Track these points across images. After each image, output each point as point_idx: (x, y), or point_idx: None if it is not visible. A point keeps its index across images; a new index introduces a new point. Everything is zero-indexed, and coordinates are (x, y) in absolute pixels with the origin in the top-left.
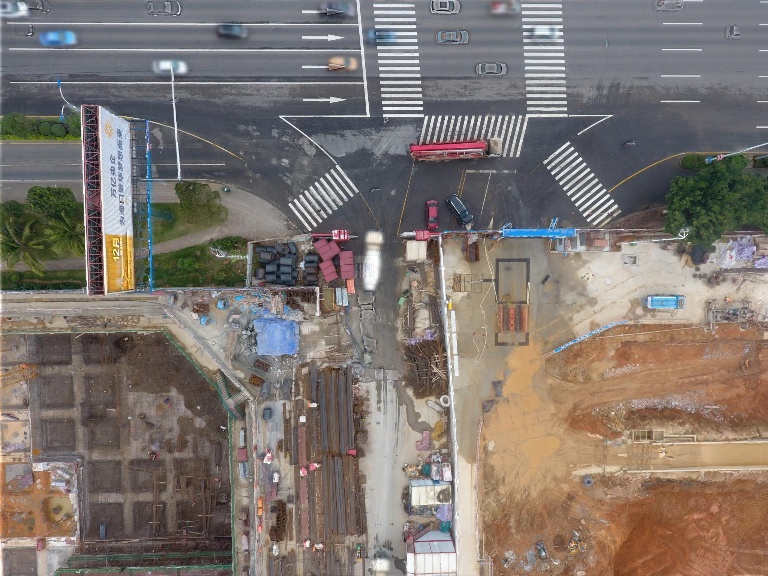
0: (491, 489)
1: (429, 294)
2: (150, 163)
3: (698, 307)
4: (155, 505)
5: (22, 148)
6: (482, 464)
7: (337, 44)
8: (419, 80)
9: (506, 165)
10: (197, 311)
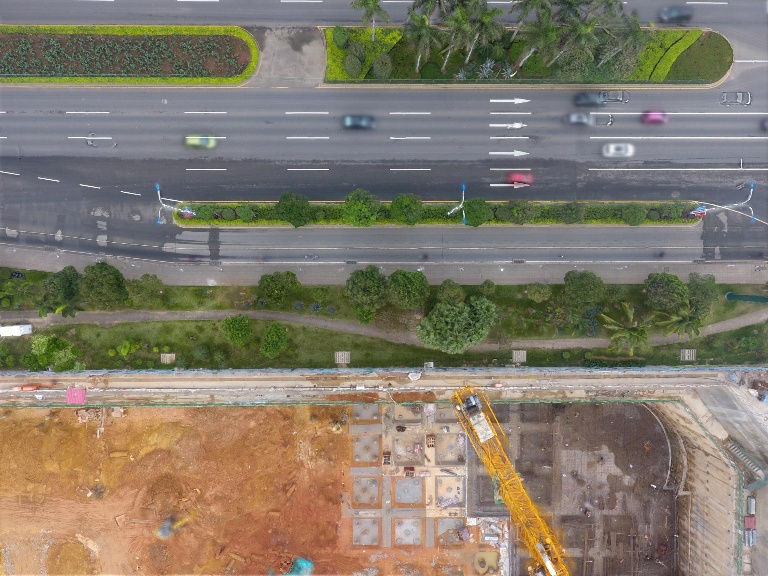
0: None
1: None
2: (715, 245)
3: None
4: (585, 561)
5: (596, 231)
6: None
7: None
8: None
9: None
10: (760, 389)
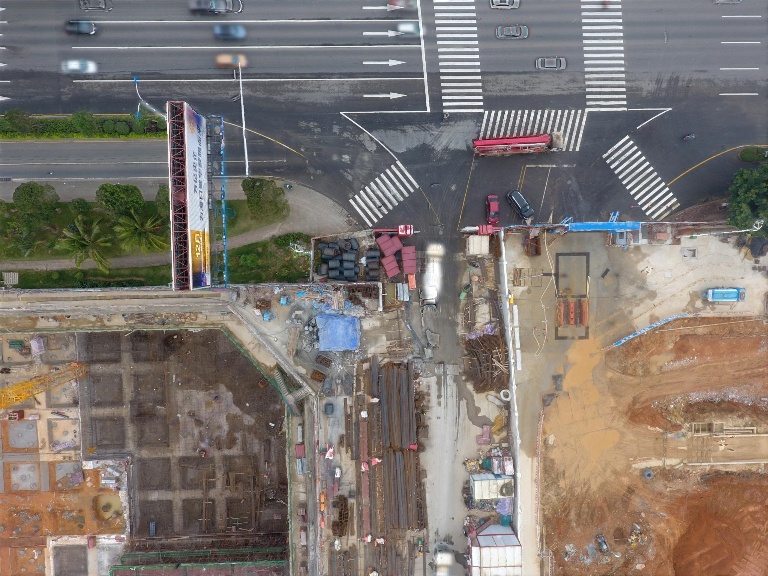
0: (551, 483)
1: (489, 289)
2: None
3: (757, 300)
4: (205, 502)
5: (85, 146)
6: (542, 458)
7: (397, 40)
8: (479, 75)
9: (566, 159)
10: (260, 307)
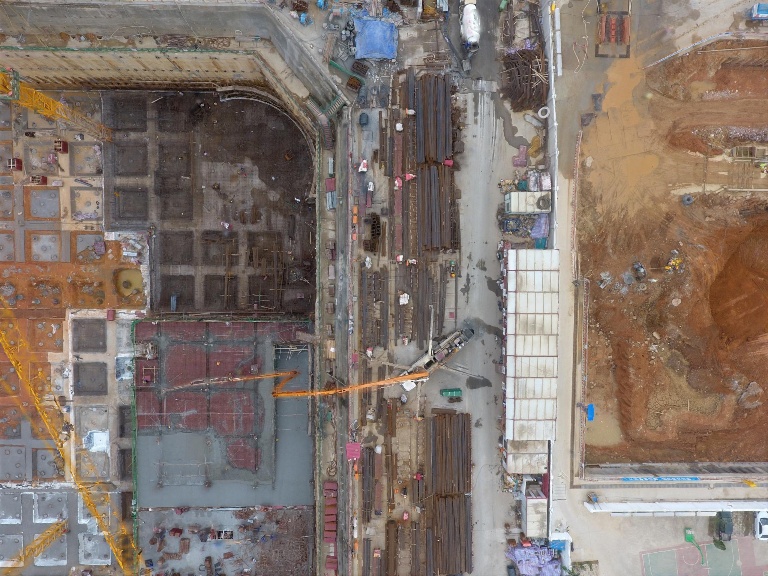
0: (588, 207)
1: (530, 2)
2: None
3: None
4: (227, 277)
5: None
6: (579, 181)
7: None
8: None
9: None
10: (297, 7)
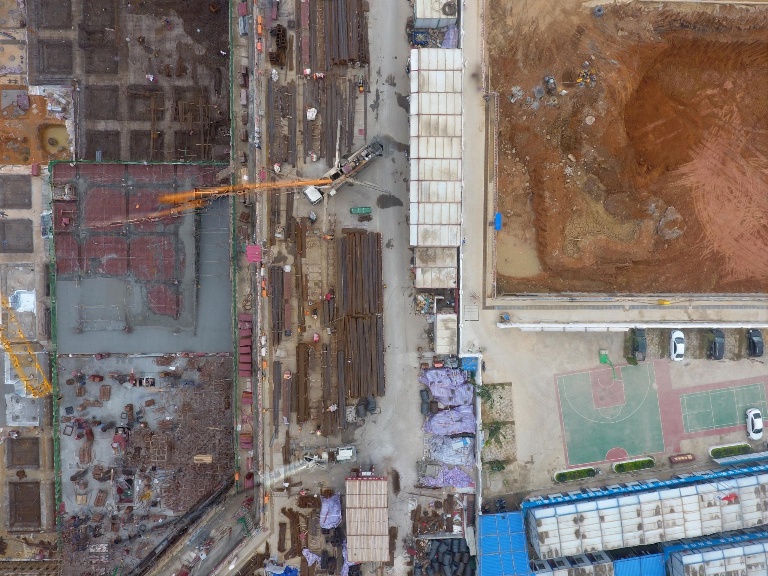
0: (498, 20)
1: None
2: None
3: None
4: (152, 132)
5: None
6: None
7: None
8: None
9: None
10: None
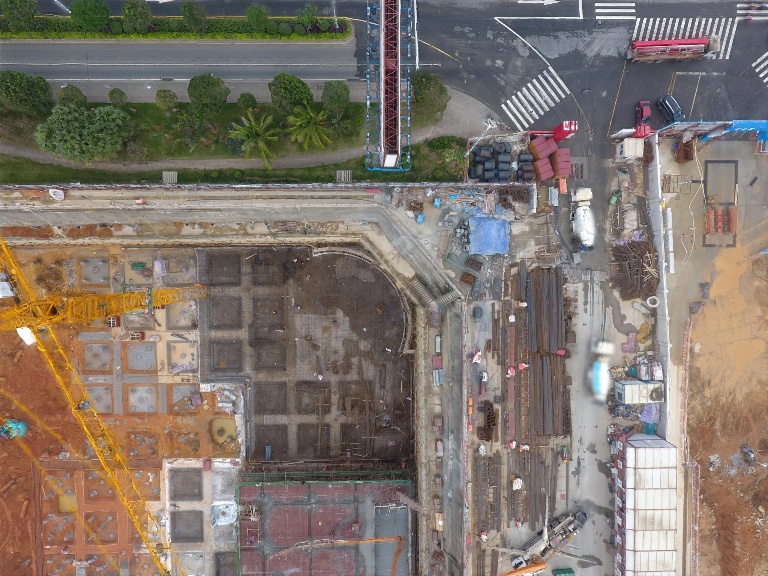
0: (696, 392)
1: (638, 195)
2: (369, 63)
3: None
4: (320, 427)
5: (246, 48)
6: None
7: None
8: None
9: (716, 67)
10: (414, 208)
